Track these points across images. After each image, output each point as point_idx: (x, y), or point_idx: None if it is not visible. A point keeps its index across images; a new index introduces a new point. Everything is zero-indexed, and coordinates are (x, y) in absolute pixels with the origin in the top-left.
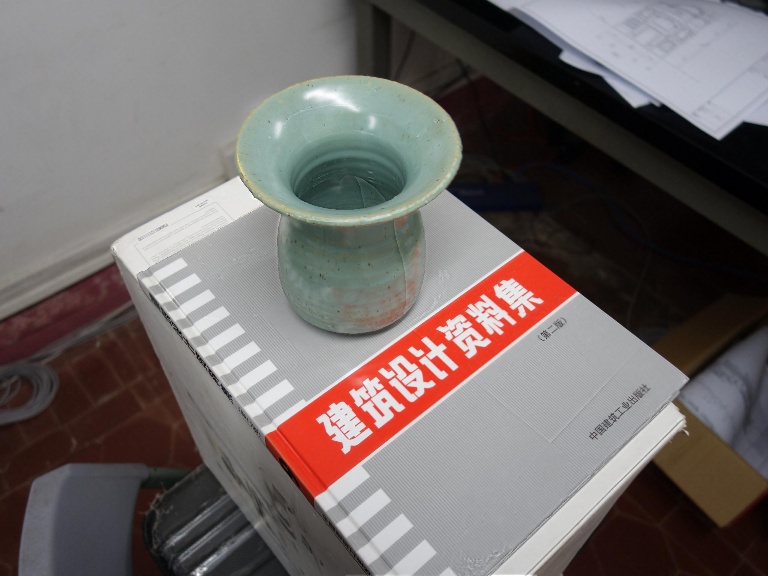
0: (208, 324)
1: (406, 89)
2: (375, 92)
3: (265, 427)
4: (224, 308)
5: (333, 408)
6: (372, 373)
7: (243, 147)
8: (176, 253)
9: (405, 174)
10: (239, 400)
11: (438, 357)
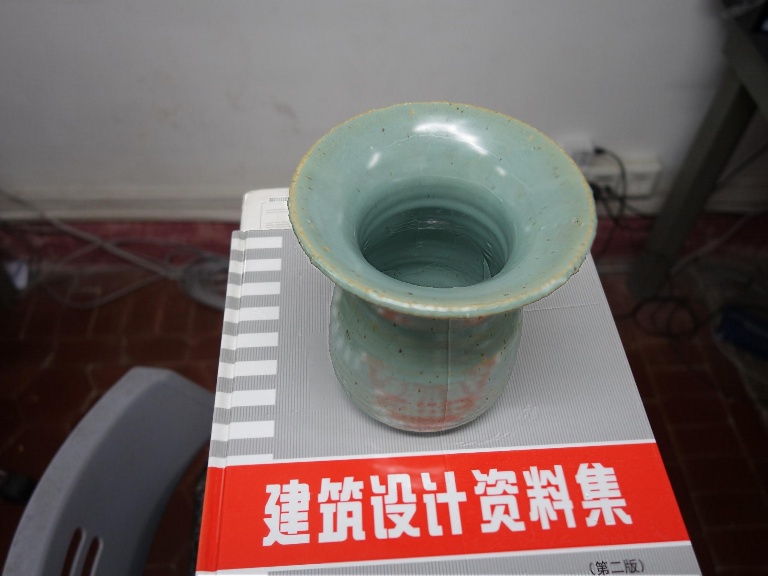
0: (252, 317)
1: (569, 164)
2: (531, 151)
3: (215, 458)
4: (278, 309)
5: (293, 485)
6: (362, 474)
7: (326, 144)
8: (281, 230)
9: (503, 267)
10: (215, 413)
11: (448, 505)
